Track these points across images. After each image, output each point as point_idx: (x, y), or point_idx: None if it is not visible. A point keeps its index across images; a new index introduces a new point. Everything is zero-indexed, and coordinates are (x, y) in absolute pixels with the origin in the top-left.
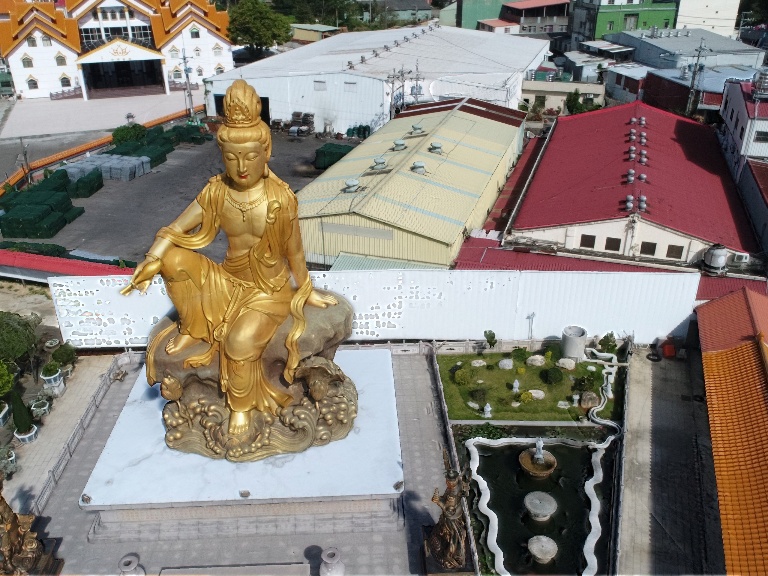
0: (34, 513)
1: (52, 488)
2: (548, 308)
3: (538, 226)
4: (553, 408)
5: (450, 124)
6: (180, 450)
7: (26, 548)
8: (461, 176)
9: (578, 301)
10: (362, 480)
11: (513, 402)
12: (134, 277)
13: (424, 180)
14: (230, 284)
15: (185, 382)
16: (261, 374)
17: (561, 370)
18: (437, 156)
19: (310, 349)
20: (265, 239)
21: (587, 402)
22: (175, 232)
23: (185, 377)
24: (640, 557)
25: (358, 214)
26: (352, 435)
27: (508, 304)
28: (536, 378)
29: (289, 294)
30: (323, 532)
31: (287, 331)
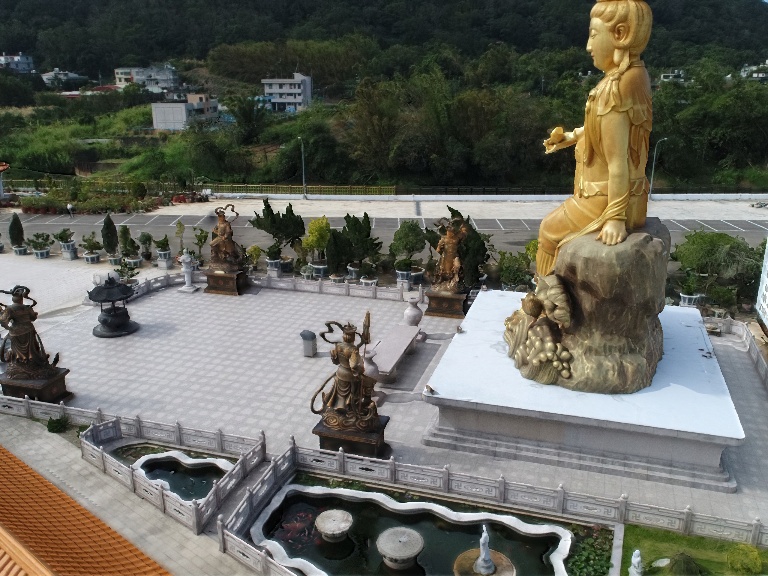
0: None
1: None
2: None
3: None
4: None
5: None
6: None
7: None
8: None
9: None
10: (453, 377)
11: None
12: None
13: None
14: None
15: None
16: None
17: None
18: None
19: None
20: None
21: None
22: None
23: None
24: None
25: None
26: (528, 382)
27: None
28: None
29: (599, 211)
30: None
31: None
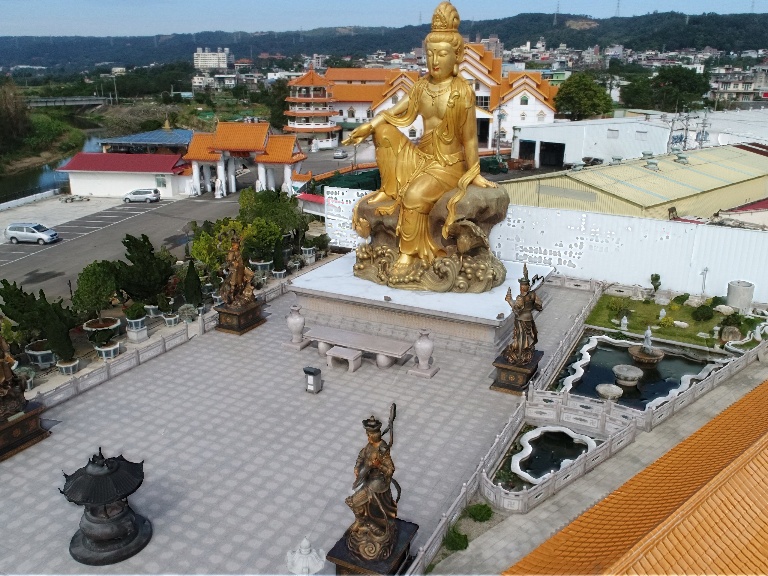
0: (262, 298)
1: (279, 295)
2: (724, 266)
3: (747, 209)
4: (691, 335)
5: (714, 152)
6: (360, 277)
7: (245, 293)
8: (695, 178)
9: (756, 262)
10: (475, 311)
11: (654, 325)
12: (352, 133)
13: (652, 173)
14: (418, 157)
15: (375, 228)
16: (427, 229)
17: (716, 313)
18: (680, 165)
19: (464, 213)
20: (445, 120)
21: (728, 335)
22: (388, 113)
23: (375, 223)
24: (700, 418)
25: (569, 177)
26: (486, 293)
27: (683, 257)
28: (687, 315)
29: (460, 172)
30: (438, 346)
31: (450, 196)
